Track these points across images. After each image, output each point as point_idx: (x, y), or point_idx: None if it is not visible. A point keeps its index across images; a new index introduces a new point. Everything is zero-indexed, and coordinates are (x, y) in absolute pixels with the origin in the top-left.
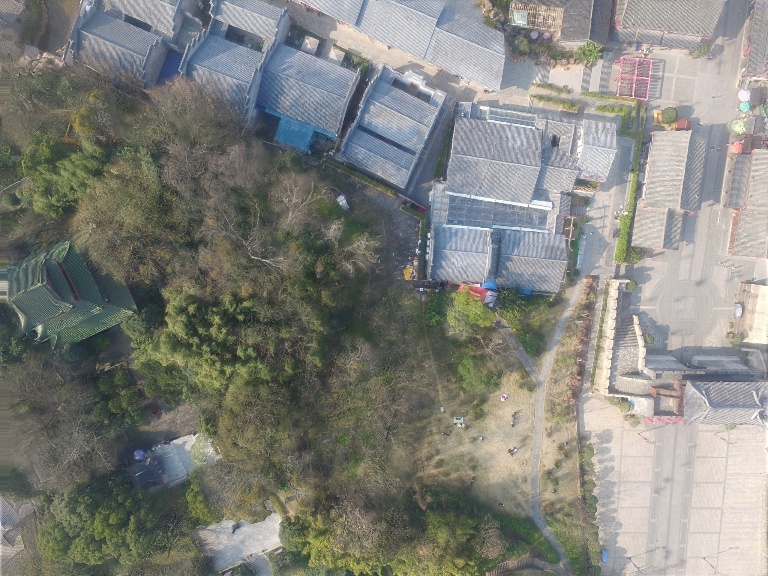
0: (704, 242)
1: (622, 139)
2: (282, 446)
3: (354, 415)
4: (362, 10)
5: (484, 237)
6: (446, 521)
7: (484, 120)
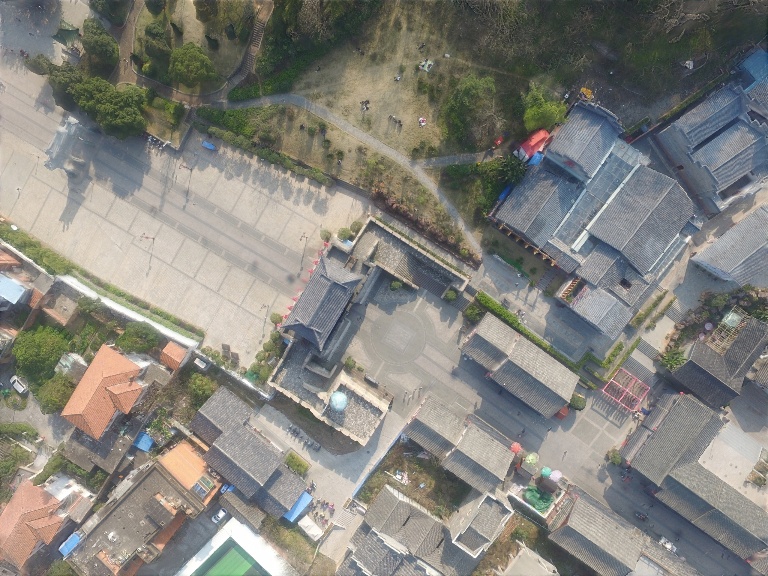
0: (447, 383)
1: (582, 352)
2: None
3: None
4: None
5: None
6: None
7: None
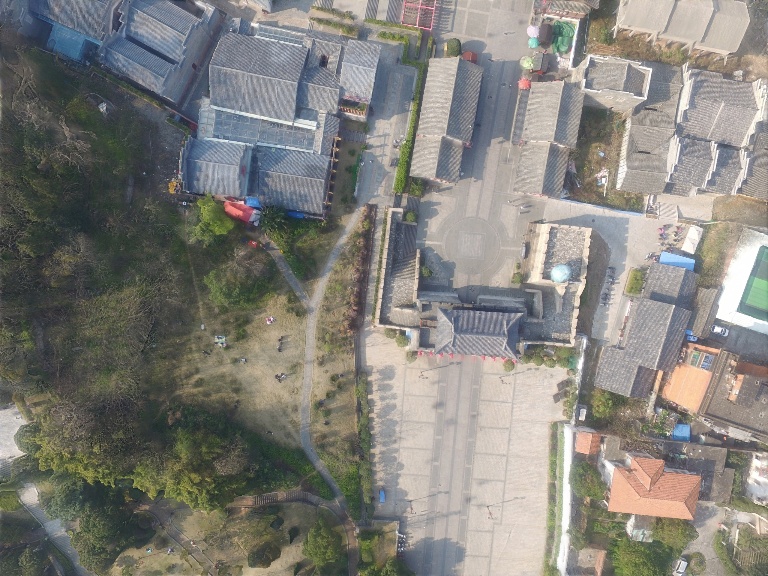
0: (493, 180)
1: (405, 68)
2: (24, 348)
3: (107, 324)
4: None
5: None
6: (194, 438)
7: None
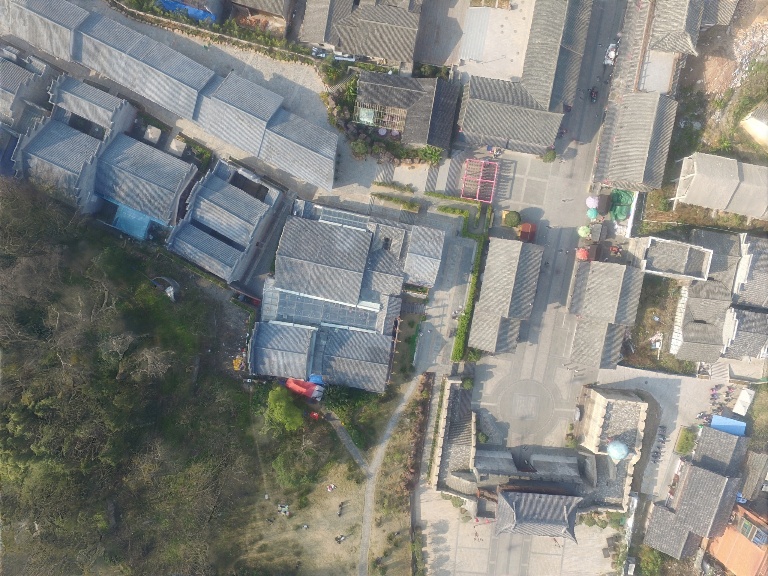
0: (548, 343)
1: (464, 240)
2: (98, 527)
3: (175, 499)
4: (198, 106)
5: (307, 336)
6: None
7: (318, 219)
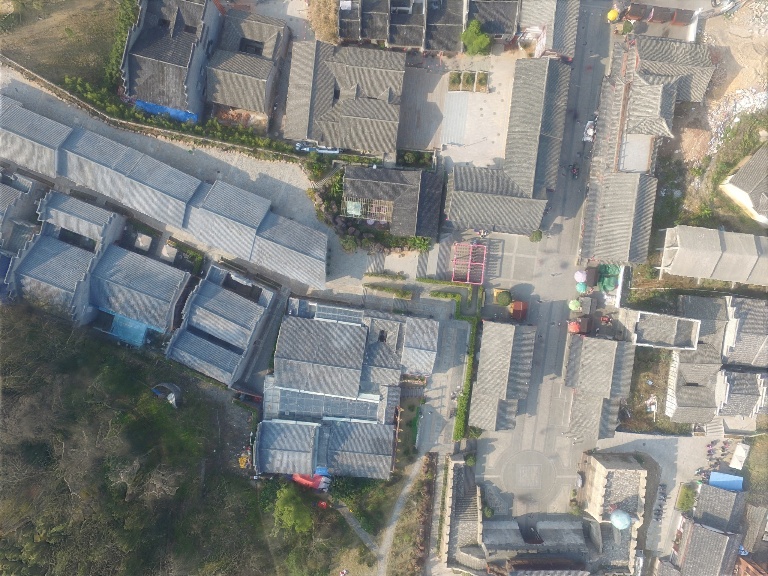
0: (546, 414)
1: (458, 322)
2: None
3: None
4: (187, 215)
5: (310, 433)
6: None
7: (313, 316)
